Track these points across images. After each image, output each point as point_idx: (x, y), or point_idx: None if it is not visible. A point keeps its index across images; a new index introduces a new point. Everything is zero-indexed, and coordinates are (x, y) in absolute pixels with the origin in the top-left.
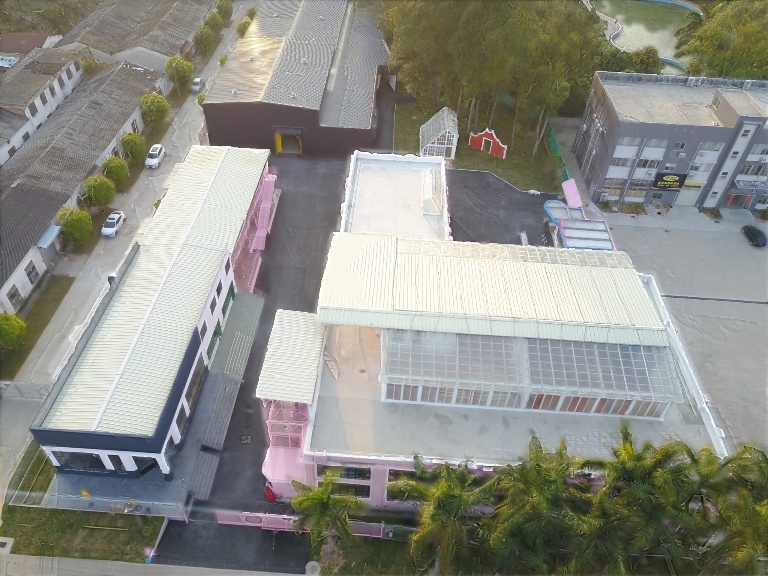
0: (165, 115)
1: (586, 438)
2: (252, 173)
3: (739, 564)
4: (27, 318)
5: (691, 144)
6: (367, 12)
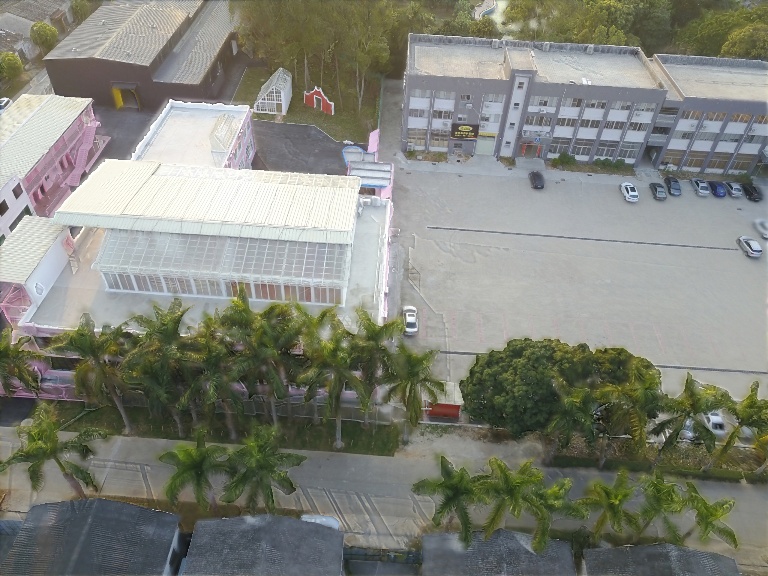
0: (18, 72)
1: None
2: (67, 117)
3: None
4: None
5: (475, 96)
6: None
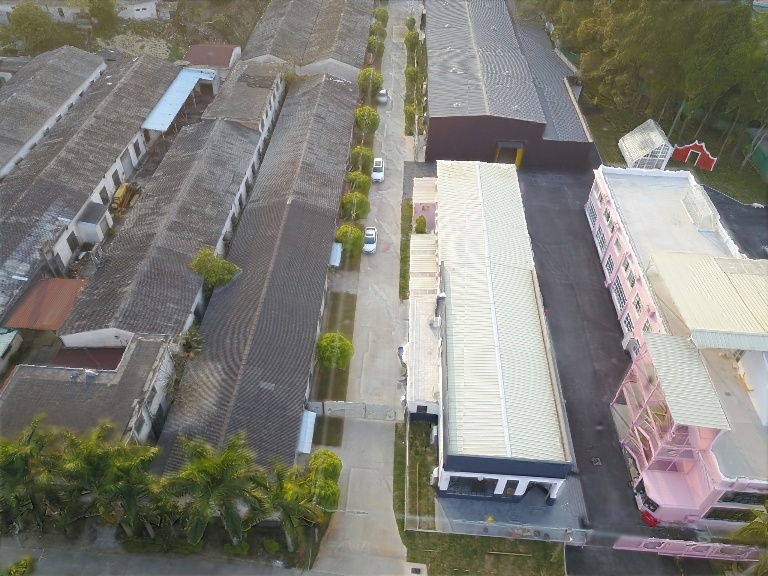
0: None
1: None
2: (512, 189)
3: None
4: None
5: None
6: (525, 21)
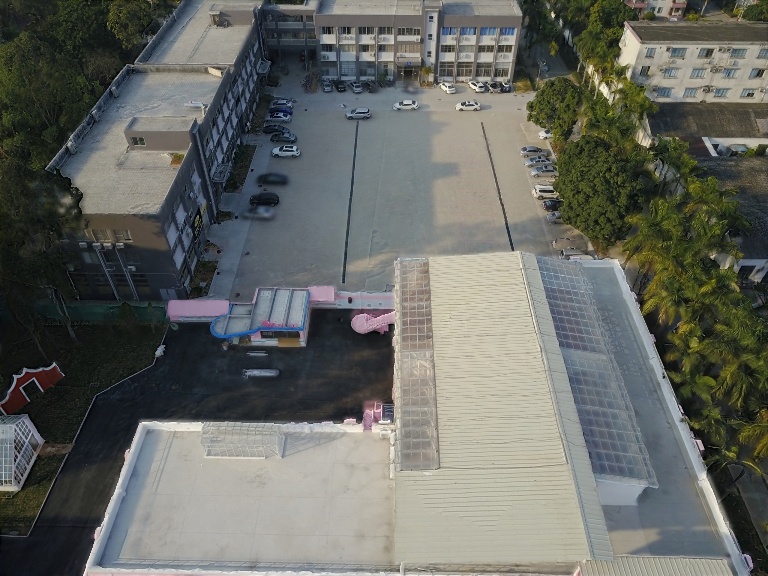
0: None
1: (610, 338)
2: None
3: None
4: None
5: (188, 182)
6: None
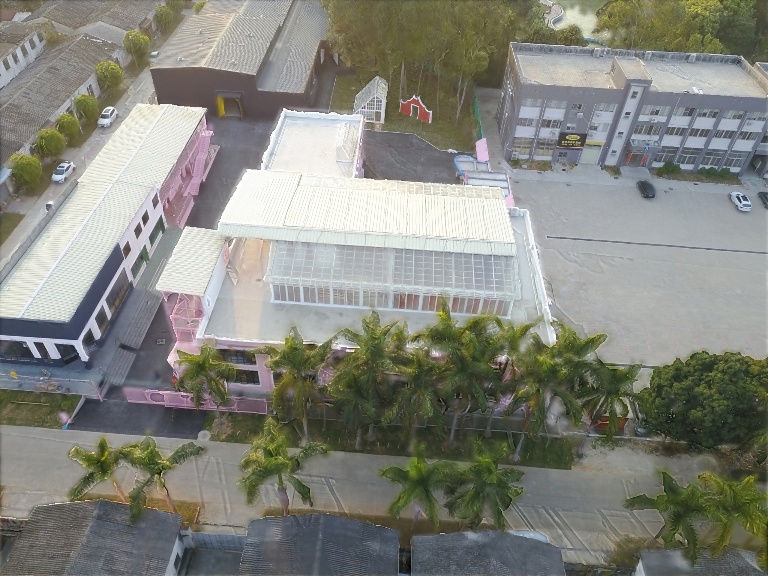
0: (119, 81)
1: None
2: (187, 126)
3: (536, 412)
4: None
5: (587, 105)
6: None
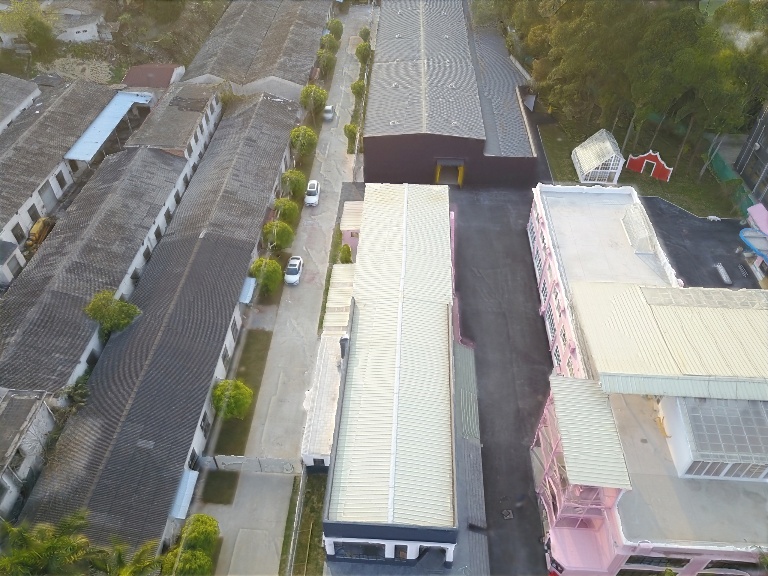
0: (314, 148)
1: None
2: (440, 213)
3: None
4: (237, 379)
5: None
6: (483, 27)
